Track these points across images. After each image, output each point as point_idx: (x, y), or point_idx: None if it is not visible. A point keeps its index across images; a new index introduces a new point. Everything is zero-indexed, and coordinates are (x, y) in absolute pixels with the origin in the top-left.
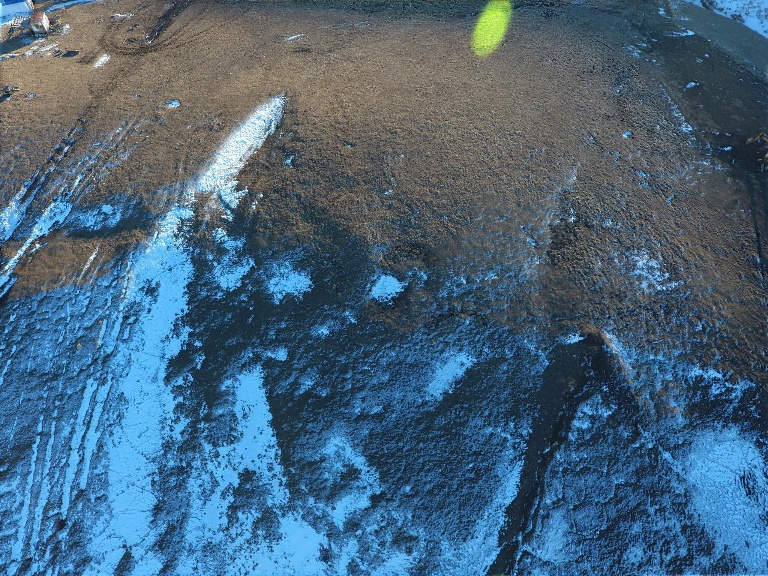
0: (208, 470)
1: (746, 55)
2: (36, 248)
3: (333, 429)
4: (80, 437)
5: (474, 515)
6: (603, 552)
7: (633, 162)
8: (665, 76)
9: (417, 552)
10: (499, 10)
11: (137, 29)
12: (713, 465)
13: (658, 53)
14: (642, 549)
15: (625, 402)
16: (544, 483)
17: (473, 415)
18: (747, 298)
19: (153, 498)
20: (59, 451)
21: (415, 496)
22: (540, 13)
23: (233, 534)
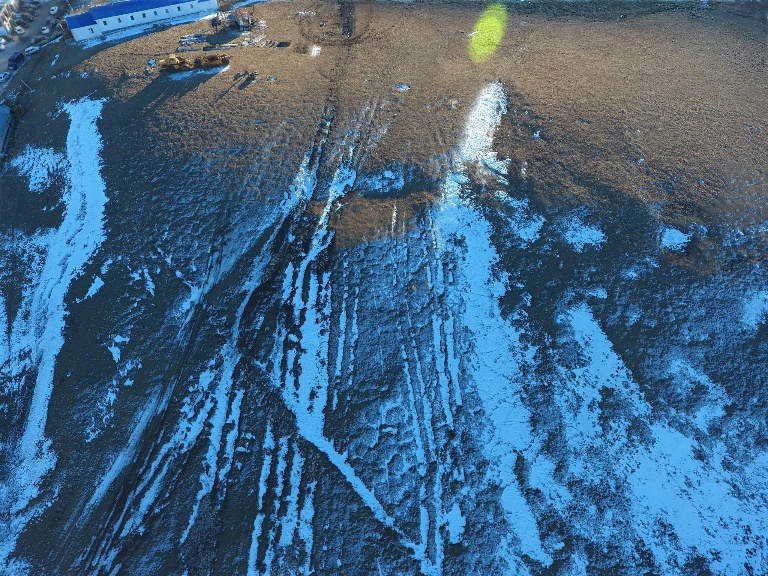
0: (569, 388)
1: None
2: (339, 207)
3: (672, 353)
4: (443, 362)
5: None
6: None
7: None
8: None
9: None
10: (645, 13)
11: (328, 25)
12: None
13: None
14: None
15: None
16: None
17: None
18: None
19: (527, 411)
20: (428, 374)
21: (763, 406)
22: (686, 15)
23: (611, 439)
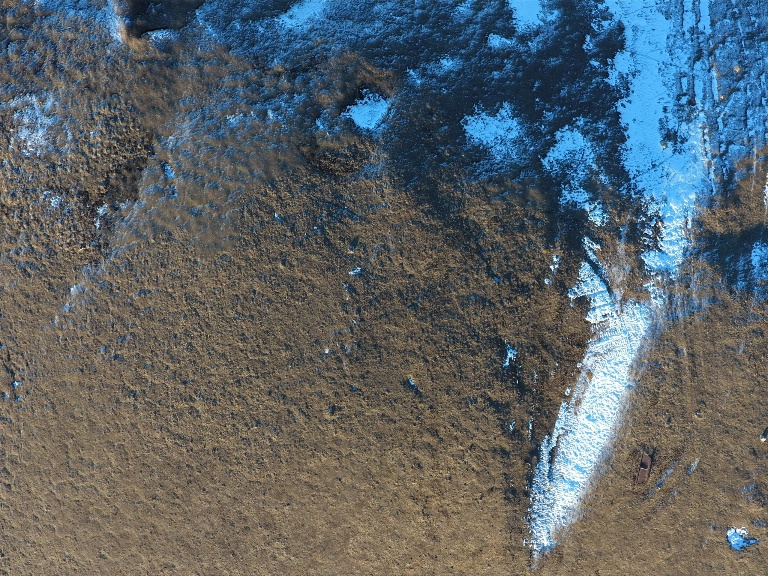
0: None
1: None
2: None
3: None
4: None
5: None
6: None
7: None
8: None
9: None
10: None
11: None
12: None
13: None
14: None
15: None
16: None
17: None
18: None
19: None
20: None
21: None
22: None
23: None
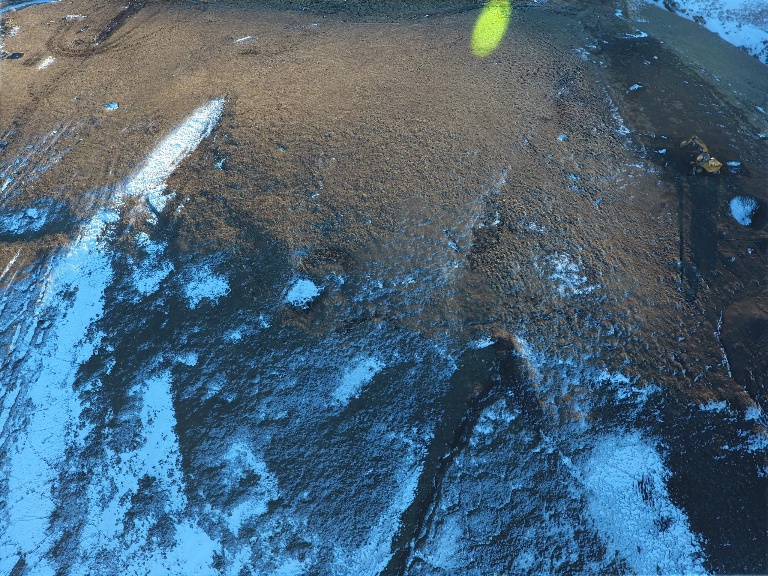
0: (109, 476)
1: (698, 57)
2: None
3: (236, 435)
4: None
5: (369, 521)
6: (494, 558)
7: (565, 165)
8: (610, 78)
9: (309, 558)
10: (453, 12)
11: (86, 31)
12: (612, 470)
13: (606, 55)
14: (533, 555)
15: (529, 407)
16: (441, 489)
17: (377, 420)
18: (663, 302)
19: (51, 505)
20: None
21: (312, 502)
22: (493, 15)
23: (128, 541)
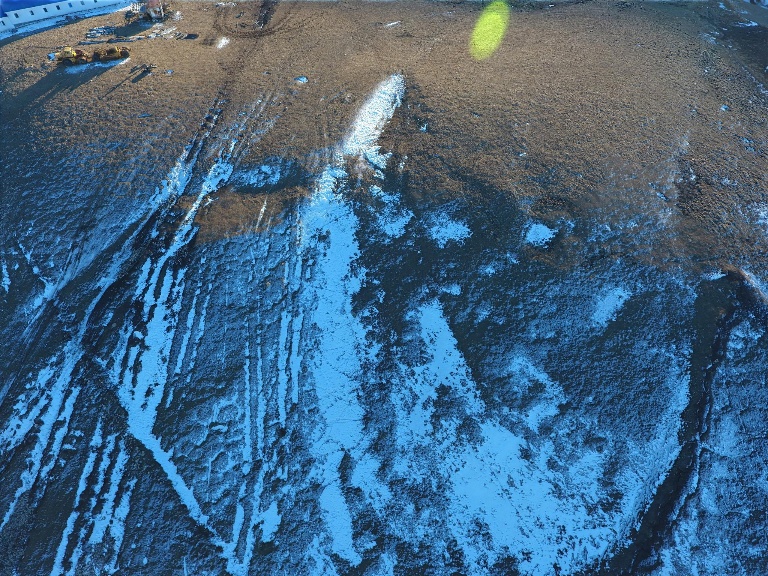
0: (407, 386)
1: None
2: (209, 202)
3: (515, 351)
4: (285, 360)
5: (653, 420)
6: None
7: (736, 131)
8: (744, 59)
9: (607, 450)
10: (575, 2)
11: (244, 16)
12: None
13: (732, 40)
14: None
15: None
16: (712, 393)
17: (638, 338)
18: None
19: (361, 409)
20: (268, 371)
21: (598, 405)
22: (615, 5)
23: (440, 438)
